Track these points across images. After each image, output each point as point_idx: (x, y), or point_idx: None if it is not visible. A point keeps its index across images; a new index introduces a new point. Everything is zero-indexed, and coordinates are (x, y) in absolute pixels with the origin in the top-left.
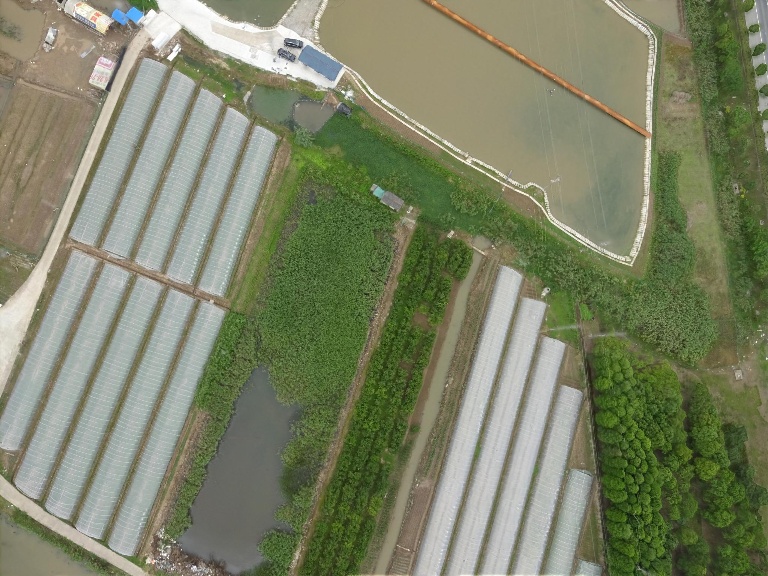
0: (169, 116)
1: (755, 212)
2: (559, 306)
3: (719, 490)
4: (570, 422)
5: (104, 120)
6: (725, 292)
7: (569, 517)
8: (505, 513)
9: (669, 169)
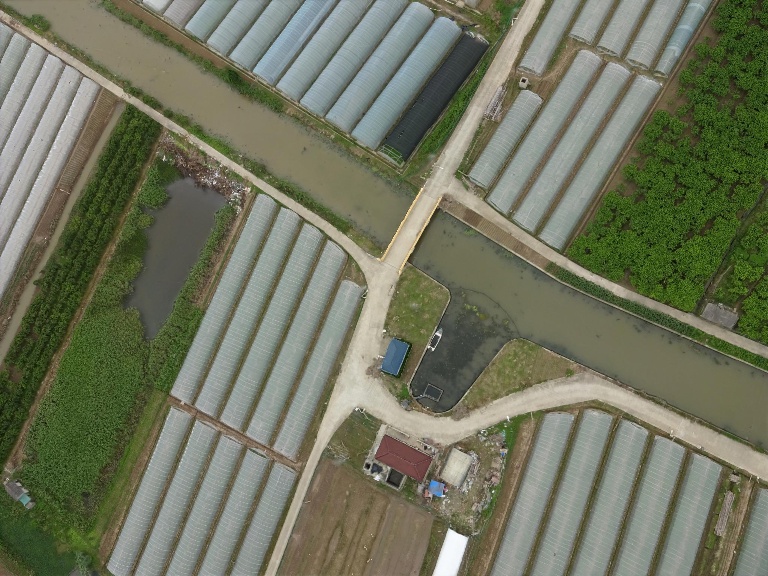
0: None
1: None
2: None
3: None
4: None
5: None
6: None
7: None
8: None
9: None
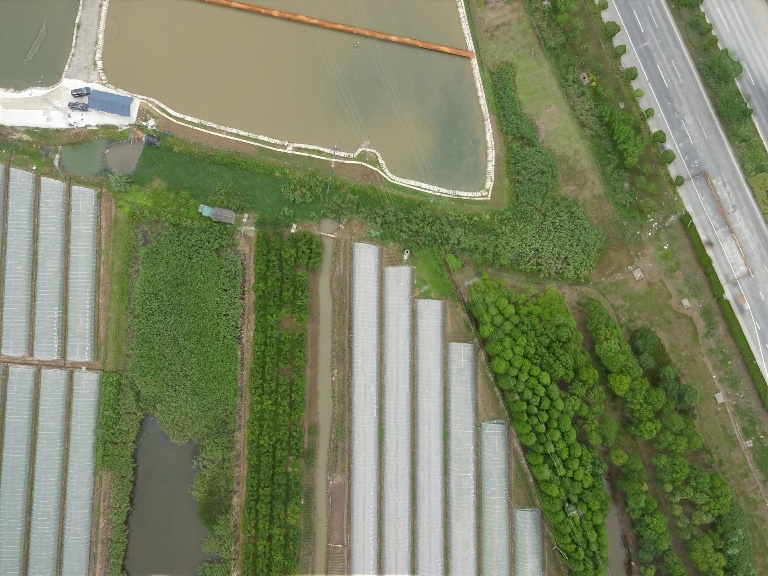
0: None
1: (612, 96)
2: (425, 264)
3: (634, 403)
4: (468, 377)
5: None
6: (601, 192)
7: (492, 471)
8: (426, 485)
9: (503, 83)
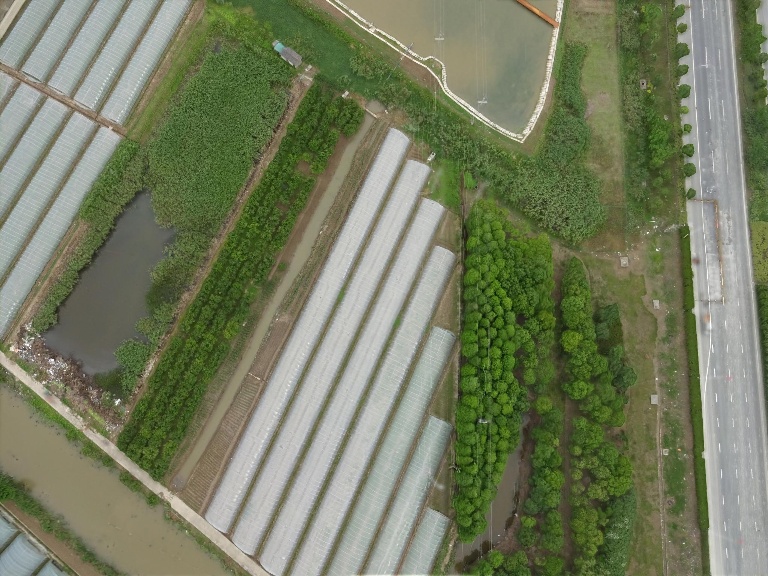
0: None
1: (660, 107)
2: (444, 172)
3: (578, 358)
4: (439, 282)
5: None
6: (619, 180)
7: (425, 372)
8: (360, 359)
9: (573, 57)
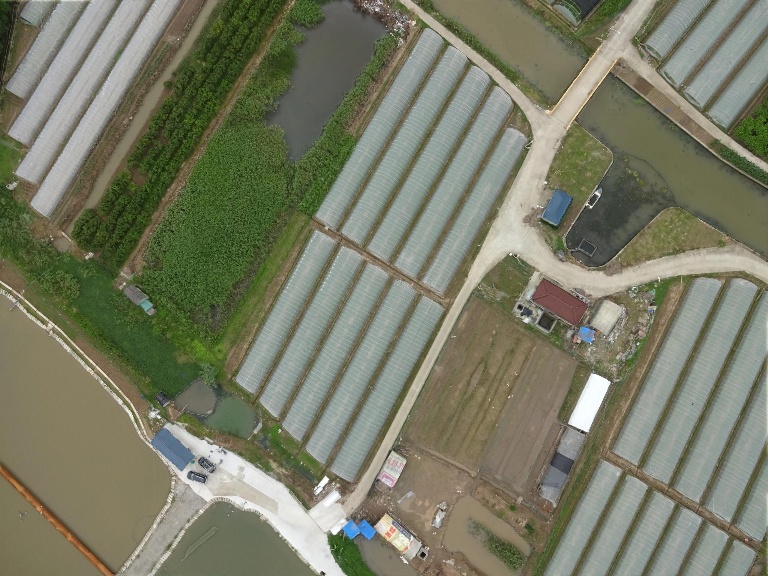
0: (335, 414)
1: None
2: (4, 171)
3: None
4: None
5: (399, 421)
6: None
7: None
8: (107, 2)
9: None
